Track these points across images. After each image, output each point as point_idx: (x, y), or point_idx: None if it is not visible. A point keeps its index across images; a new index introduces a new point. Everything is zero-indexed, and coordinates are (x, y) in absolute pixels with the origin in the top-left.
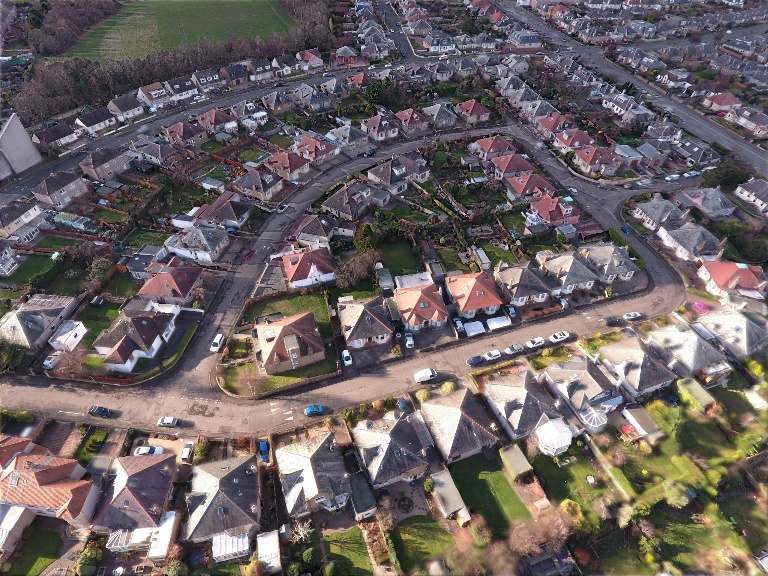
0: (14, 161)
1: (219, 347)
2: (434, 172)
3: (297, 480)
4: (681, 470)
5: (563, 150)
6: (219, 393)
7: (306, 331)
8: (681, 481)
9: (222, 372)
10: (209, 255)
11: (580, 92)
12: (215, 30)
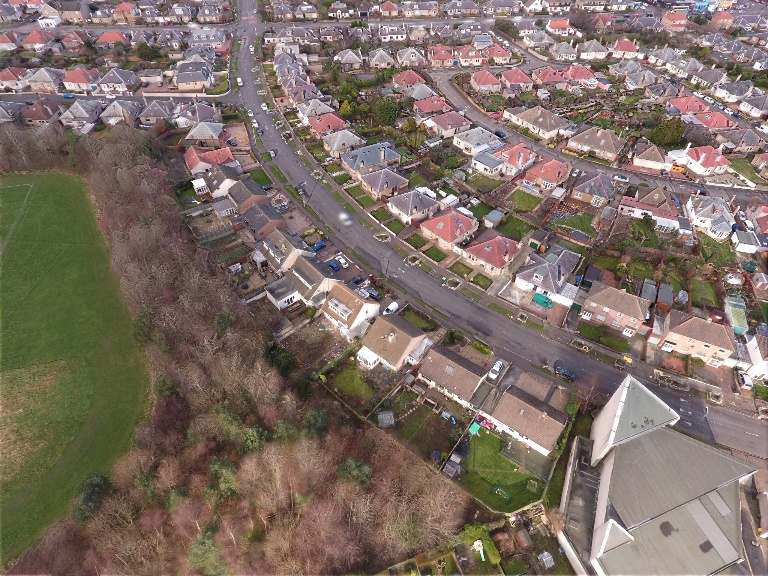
0: None
1: None
2: None
3: None
4: (761, 84)
5: (478, 63)
6: None
7: None
8: None
9: None
10: None
11: None
12: None
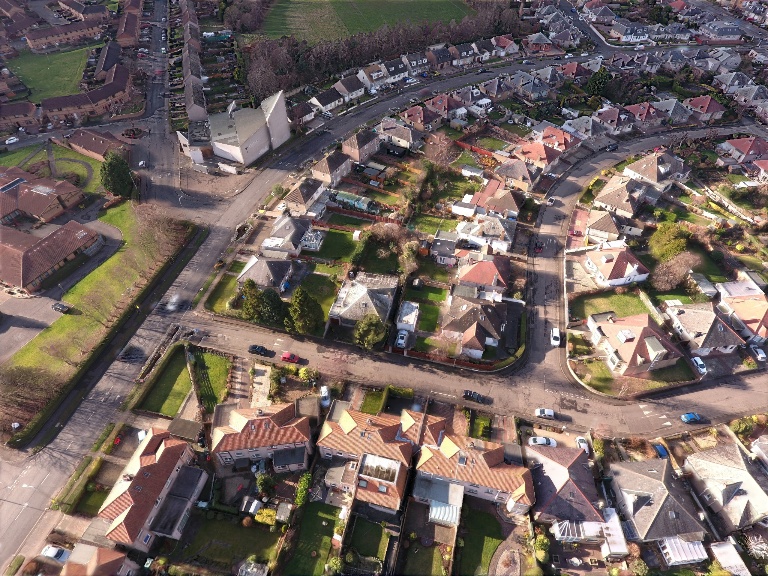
0: (274, 137)
1: (559, 341)
2: (691, 172)
3: (736, 492)
4: None
5: None
6: (581, 389)
7: (660, 334)
8: None
9: (576, 368)
10: (507, 245)
11: None
12: (390, 11)
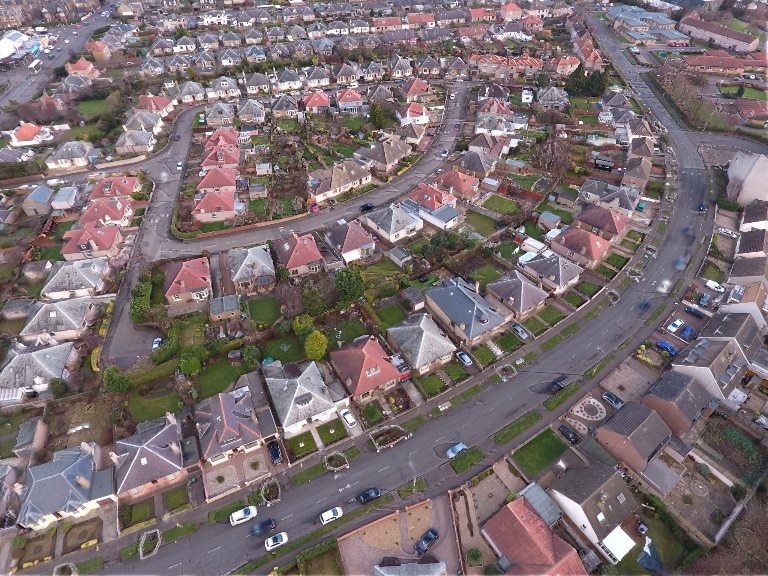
0: None
1: None
2: None
3: None
4: None
5: None
6: None
7: None
8: (273, 64)
9: None
10: None
11: None
12: None
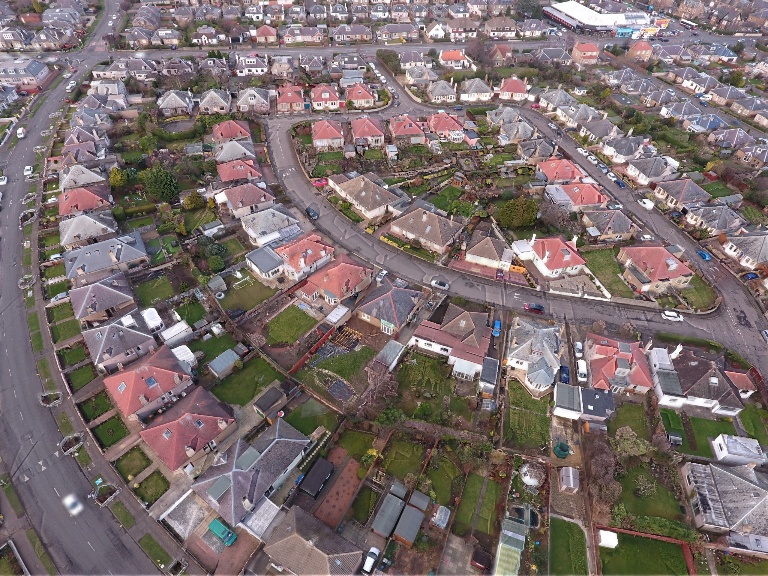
0: None
1: None
2: None
3: None
4: None
5: (334, 107)
6: (721, 310)
7: None
8: None
9: None
10: None
11: (205, 77)
12: None
